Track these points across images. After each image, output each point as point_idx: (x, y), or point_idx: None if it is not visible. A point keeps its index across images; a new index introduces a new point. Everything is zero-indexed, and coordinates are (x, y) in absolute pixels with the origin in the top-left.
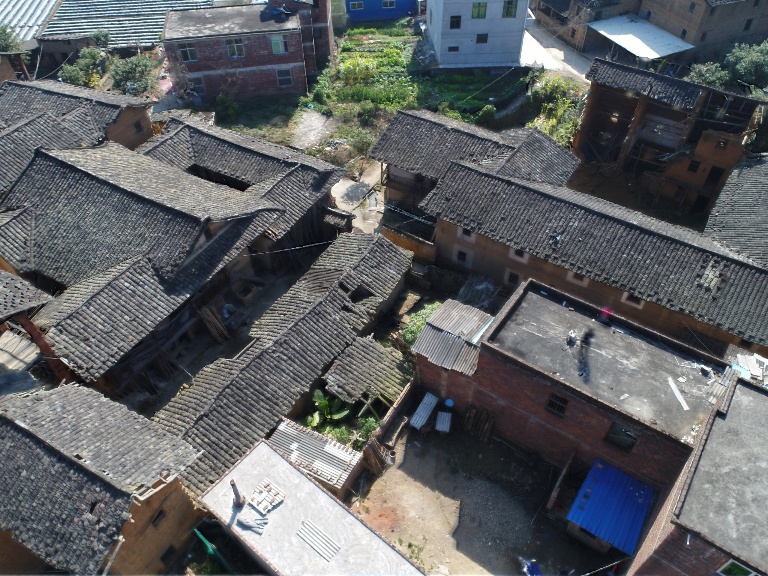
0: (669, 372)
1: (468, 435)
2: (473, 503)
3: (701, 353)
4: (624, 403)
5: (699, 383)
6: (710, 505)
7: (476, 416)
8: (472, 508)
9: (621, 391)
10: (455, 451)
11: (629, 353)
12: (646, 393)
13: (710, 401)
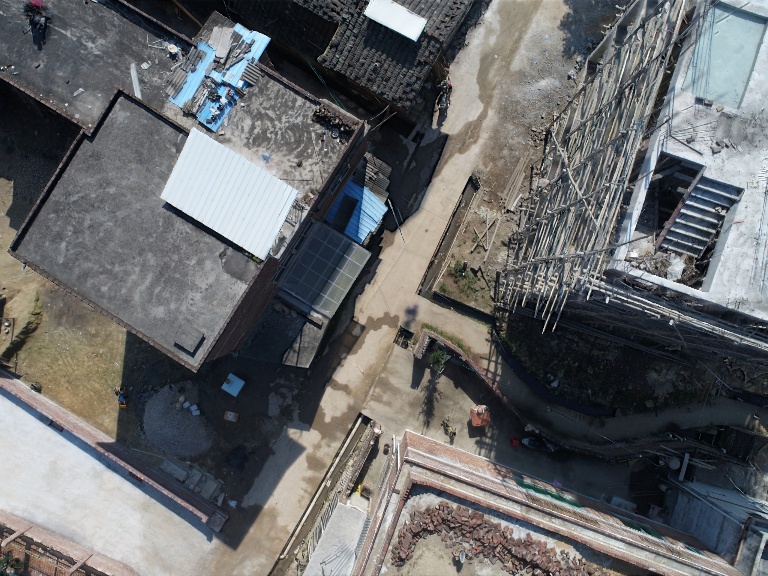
0: (134, 56)
1: (25, 109)
2: (24, 182)
3: (168, 30)
4: (76, 100)
5: (163, 69)
6: (48, 234)
7: (19, 92)
8: (23, 187)
9: (76, 85)
10: (12, 128)
11: (97, 32)
12: (102, 86)
13: (167, 92)
